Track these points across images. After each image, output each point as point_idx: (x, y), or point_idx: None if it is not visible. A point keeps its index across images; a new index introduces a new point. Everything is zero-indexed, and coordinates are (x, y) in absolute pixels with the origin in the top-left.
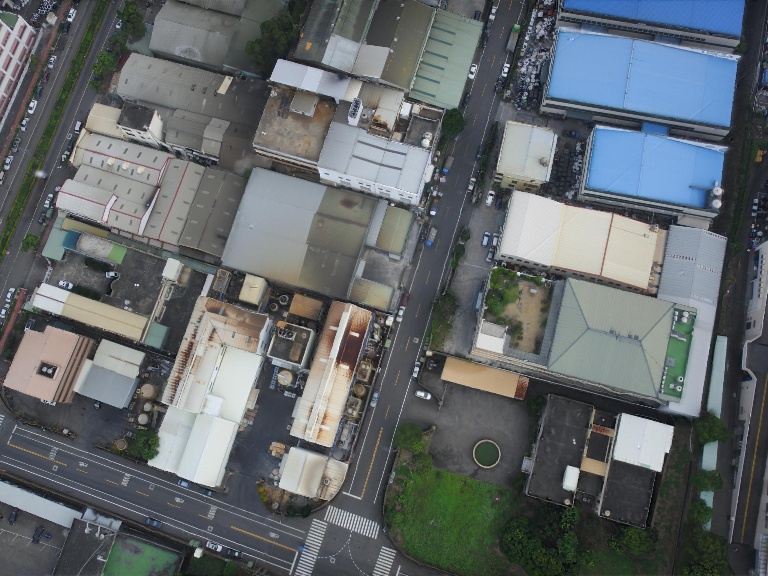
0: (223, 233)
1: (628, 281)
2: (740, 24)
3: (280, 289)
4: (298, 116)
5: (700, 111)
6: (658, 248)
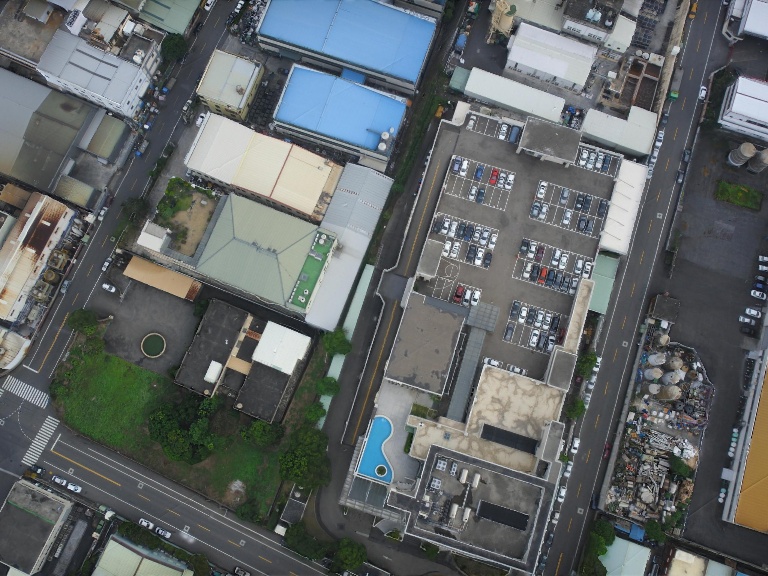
0: None
1: (295, 206)
2: None
3: (0, 179)
4: (33, 21)
5: (391, 64)
6: (332, 181)
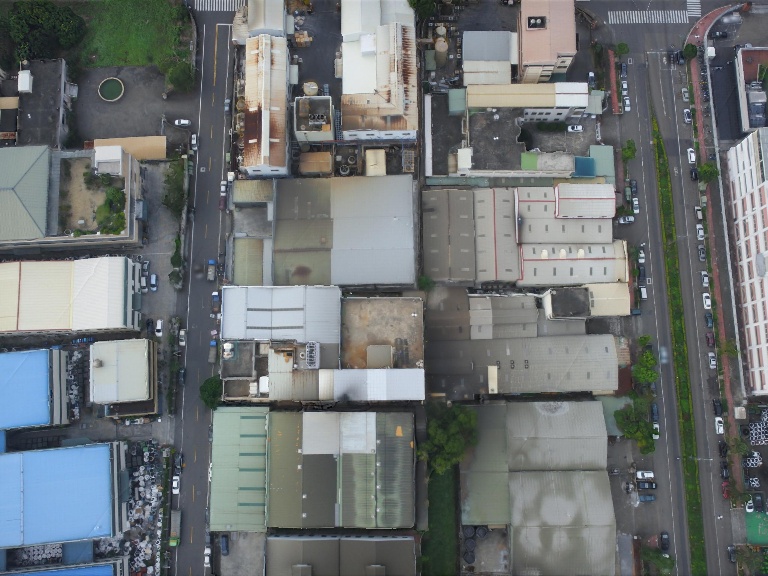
0: (430, 215)
1: None
2: None
3: None
4: None
5: None
6: None
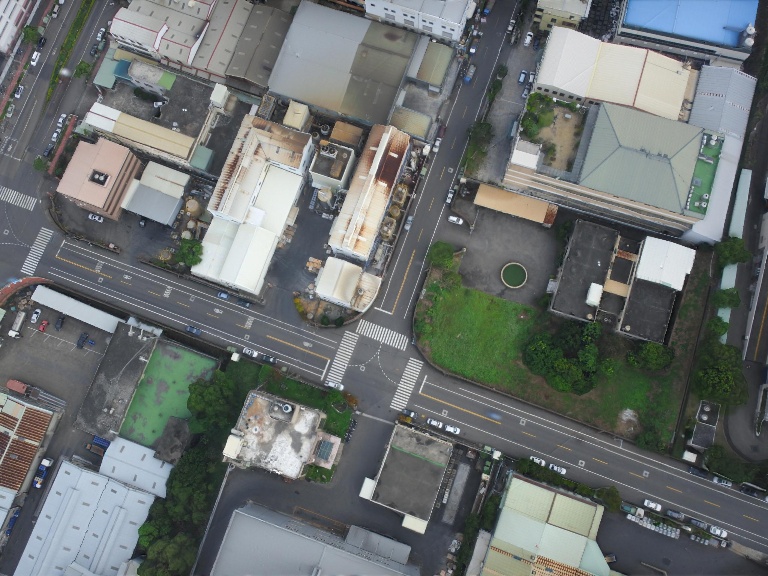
0: (269, 65)
1: (659, 113)
2: None
3: (322, 119)
4: None
5: None
6: (689, 87)
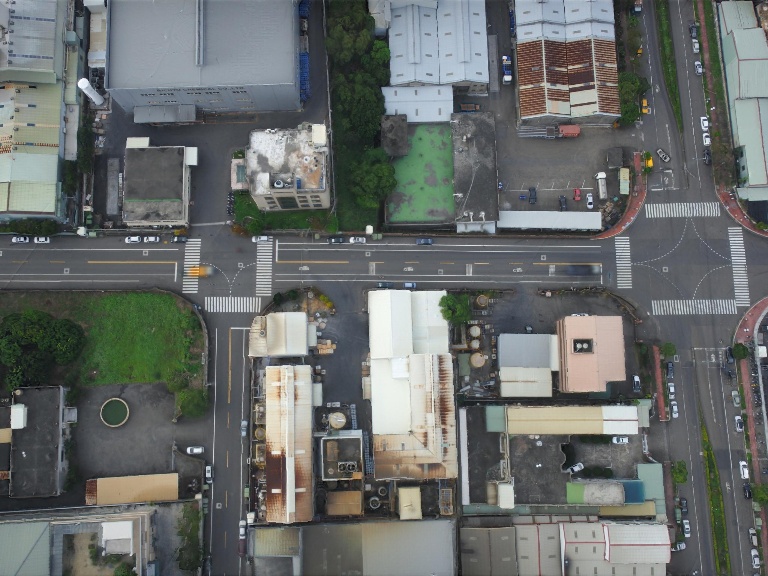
0: (469, 557)
1: None
2: None
3: (383, 513)
4: None
5: None
6: None
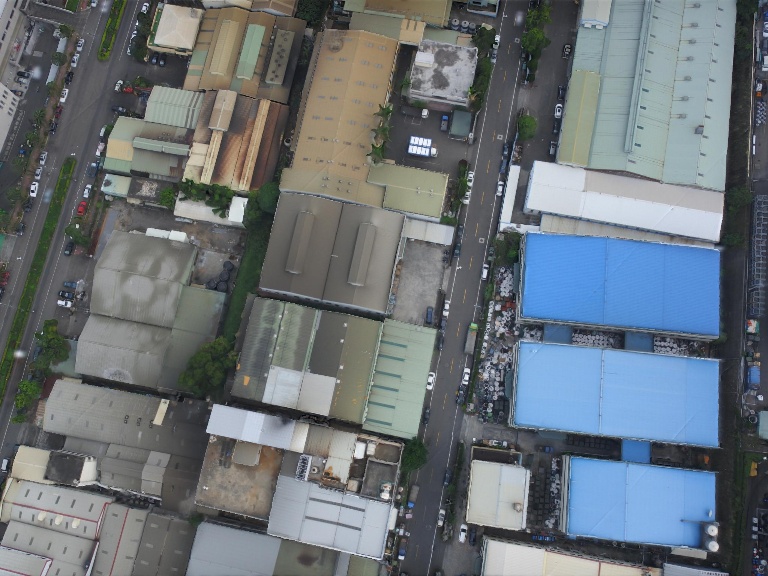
0: None
1: None
2: (717, 316)
3: None
4: (242, 464)
5: (684, 427)
6: None
